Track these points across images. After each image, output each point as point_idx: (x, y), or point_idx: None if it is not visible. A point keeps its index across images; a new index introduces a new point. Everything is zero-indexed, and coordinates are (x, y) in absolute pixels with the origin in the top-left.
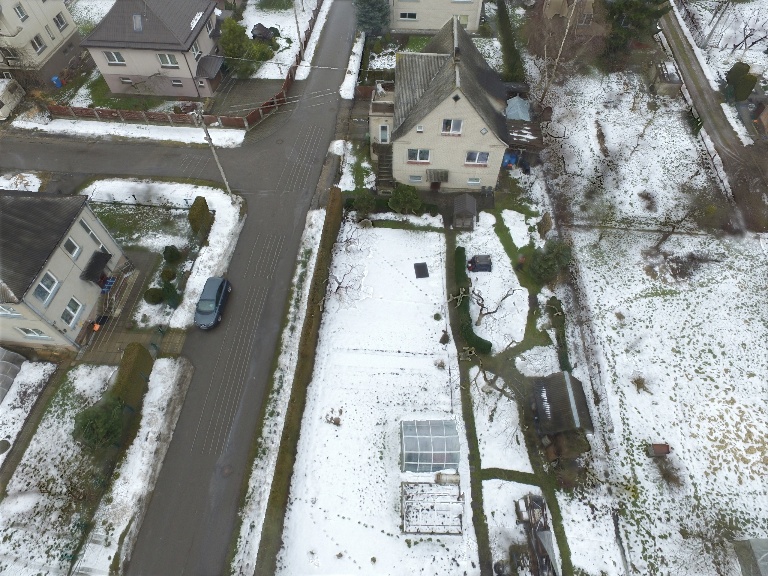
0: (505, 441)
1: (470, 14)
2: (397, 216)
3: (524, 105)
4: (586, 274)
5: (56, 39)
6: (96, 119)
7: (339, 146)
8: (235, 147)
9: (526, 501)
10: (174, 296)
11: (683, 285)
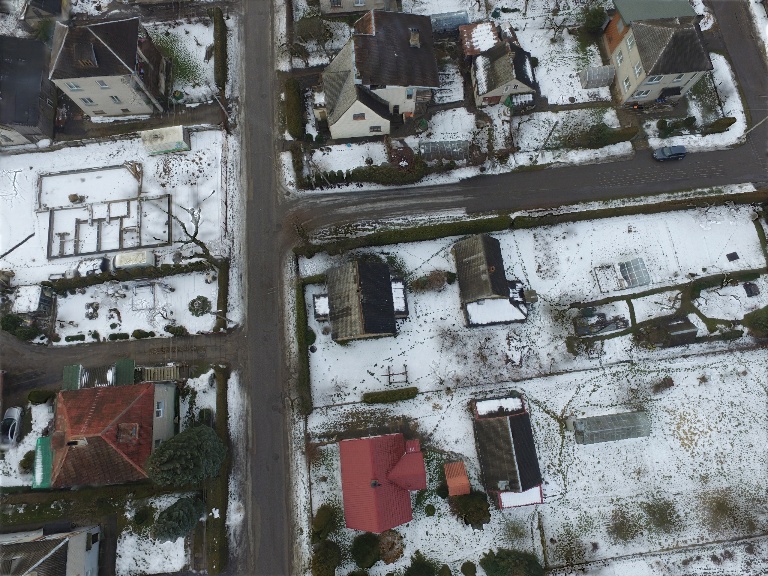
0: (647, 310)
1: None
2: None
3: None
4: None
5: None
6: None
7: None
8: None
9: None
10: (667, 134)
11: None
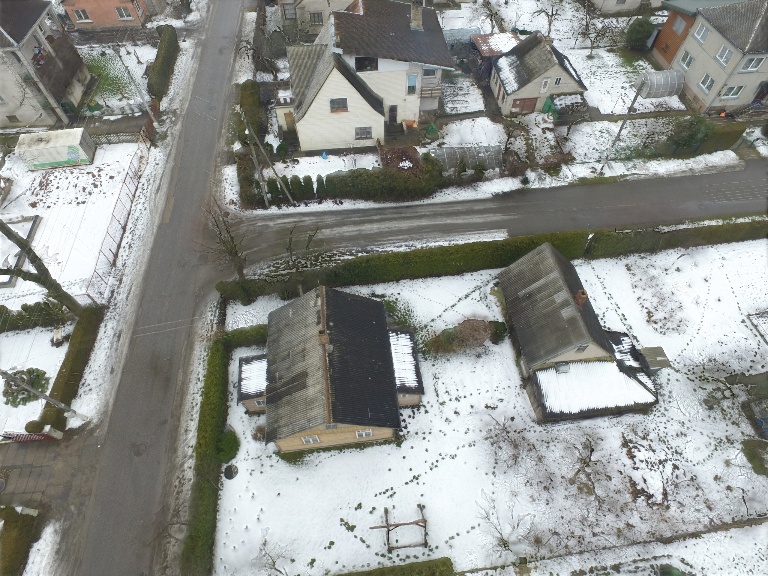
0: None
1: None
2: None
3: None
4: None
5: None
6: None
7: None
8: None
9: None
10: None
11: None
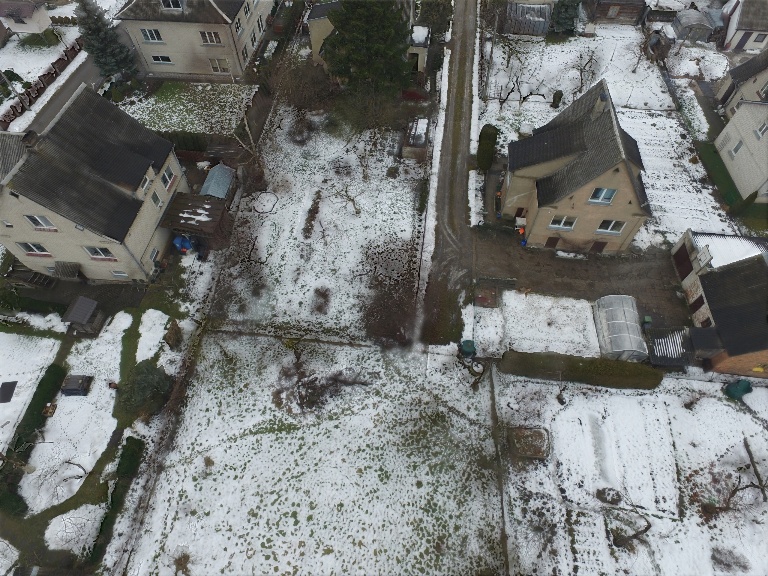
0: None
1: None
2: (19, 316)
3: (226, 174)
4: (202, 399)
5: None
6: None
7: None
8: None
9: None
10: None
11: (308, 417)
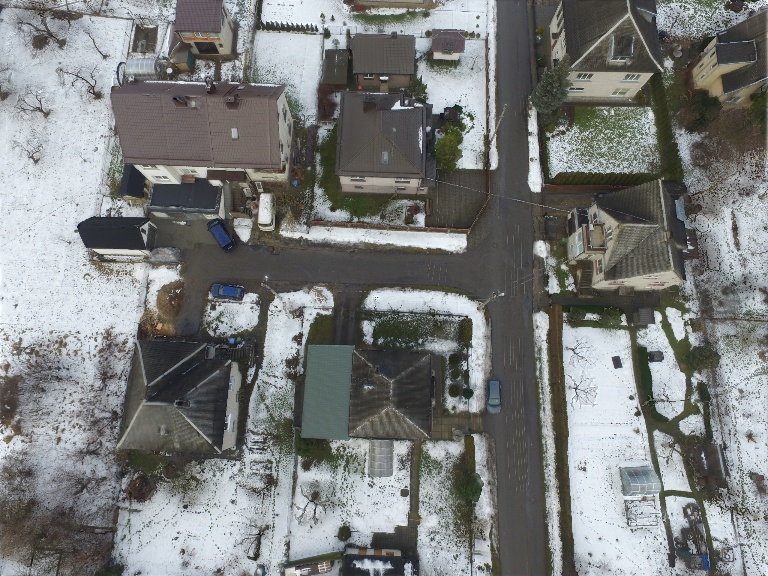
0: (676, 475)
1: (632, 88)
2: (595, 317)
3: (682, 208)
4: (721, 359)
5: (289, 145)
6: (346, 227)
7: (542, 250)
8: (463, 252)
9: (690, 509)
10: None
11: None
